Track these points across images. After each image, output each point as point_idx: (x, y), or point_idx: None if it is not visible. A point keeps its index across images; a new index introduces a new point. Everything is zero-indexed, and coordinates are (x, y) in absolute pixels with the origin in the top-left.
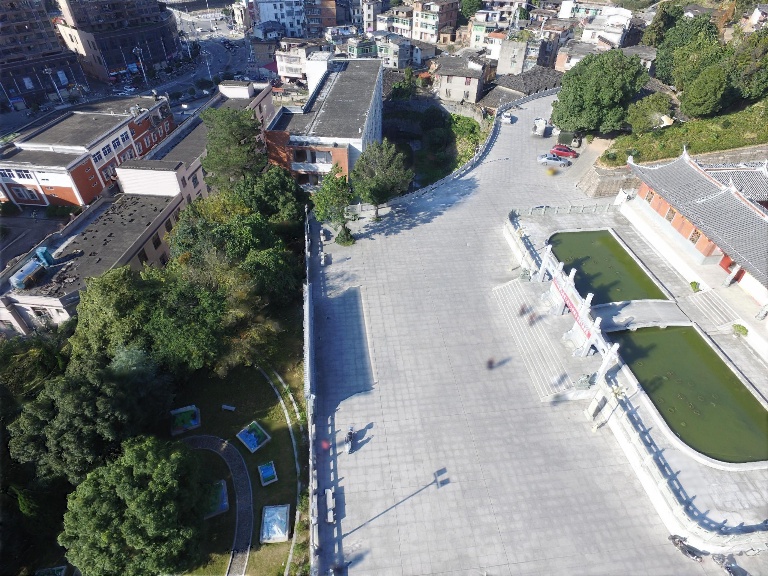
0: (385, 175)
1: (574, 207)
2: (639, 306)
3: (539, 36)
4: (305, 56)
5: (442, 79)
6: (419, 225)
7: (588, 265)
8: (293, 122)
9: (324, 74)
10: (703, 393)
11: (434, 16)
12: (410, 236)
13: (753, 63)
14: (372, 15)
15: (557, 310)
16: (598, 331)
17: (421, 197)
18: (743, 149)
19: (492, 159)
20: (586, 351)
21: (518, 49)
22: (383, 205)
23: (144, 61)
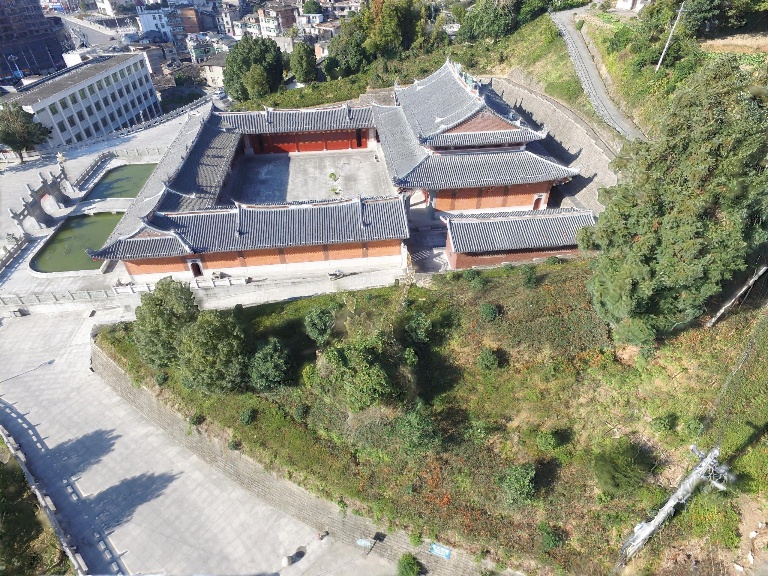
0: (5, 126)
1: (160, 149)
2: (110, 201)
3: (301, 32)
4: (147, 58)
5: (205, 69)
6: (49, 165)
7: (121, 182)
8: (1, 97)
9: (77, 65)
10: (86, 244)
11: (273, 21)
12: (33, 172)
13: (342, 41)
14: (230, 22)
15: (54, 205)
16: (22, 206)
17: (76, 149)
18: (322, 106)
19: (168, 124)
20: (36, 224)
21: (287, 43)
22: (36, 154)
23: (30, 68)
